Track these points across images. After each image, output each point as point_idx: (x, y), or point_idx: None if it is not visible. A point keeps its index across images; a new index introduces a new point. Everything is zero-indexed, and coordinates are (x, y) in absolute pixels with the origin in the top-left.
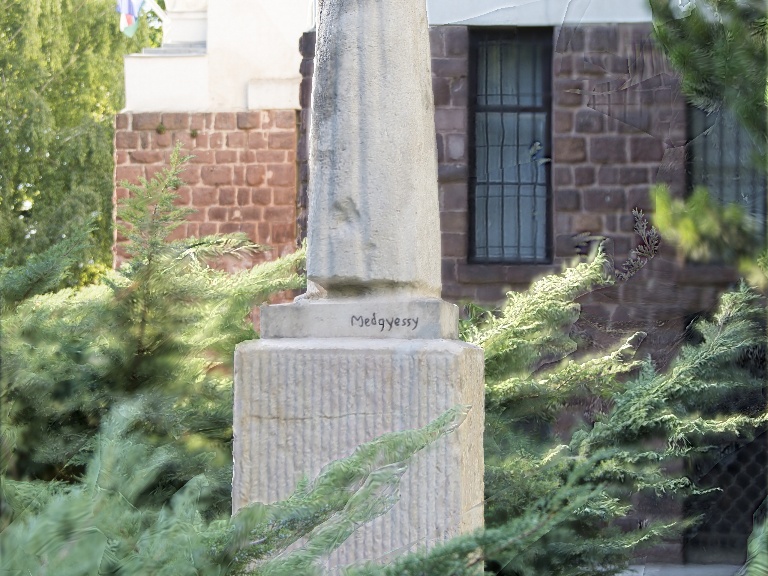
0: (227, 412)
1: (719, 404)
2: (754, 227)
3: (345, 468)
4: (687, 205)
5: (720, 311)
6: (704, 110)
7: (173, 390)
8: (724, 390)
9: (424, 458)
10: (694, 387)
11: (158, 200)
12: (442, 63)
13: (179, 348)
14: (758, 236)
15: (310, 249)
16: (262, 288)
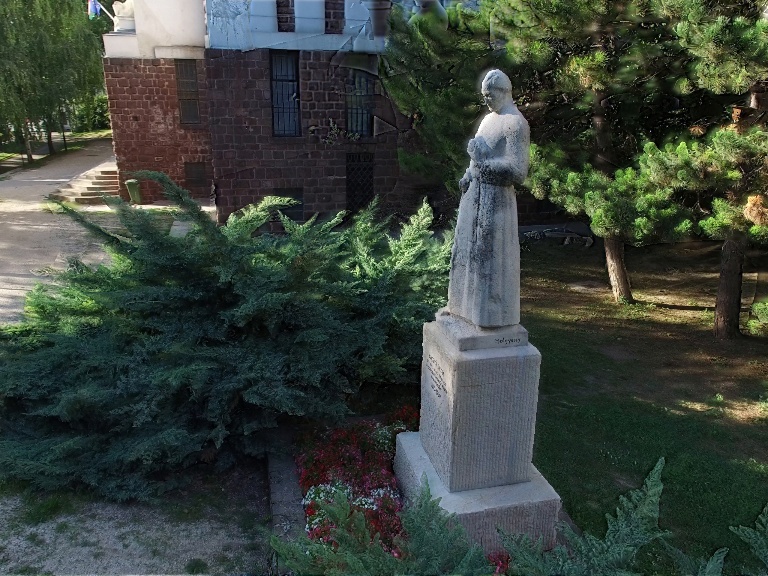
0: None
1: None
2: (436, 166)
3: (652, 515)
4: (408, 155)
5: (456, 216)
6: (407, 116)
7: (303, 284)
8: None
9: (526, 394)
10: None
11: None
12: (261, 63)
13: (310, 273)
14: (437, 169)
15: (480, 315)
16: None
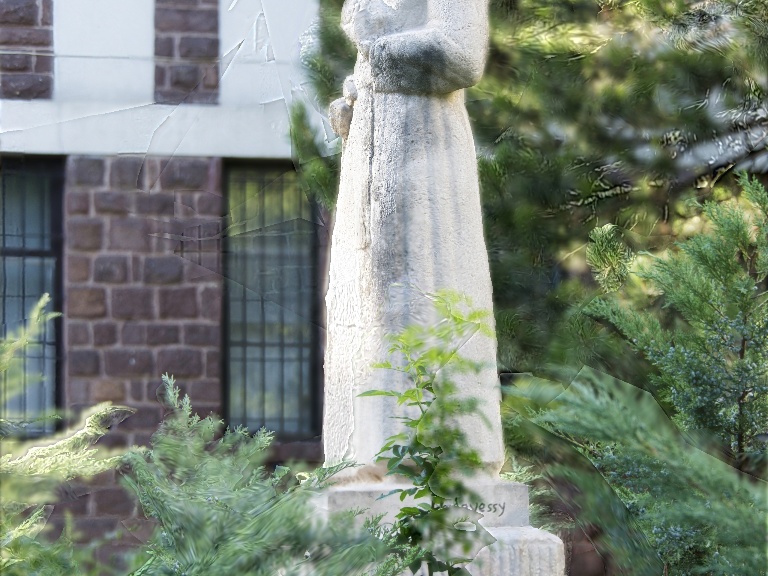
0: None
1: None
2: None
3: None
4: None
5: None
6: None
7: None
8: None
9: None
10: None
11: (5, 365)
12: None
13: None
14: None
15: None
16: (102, 470)
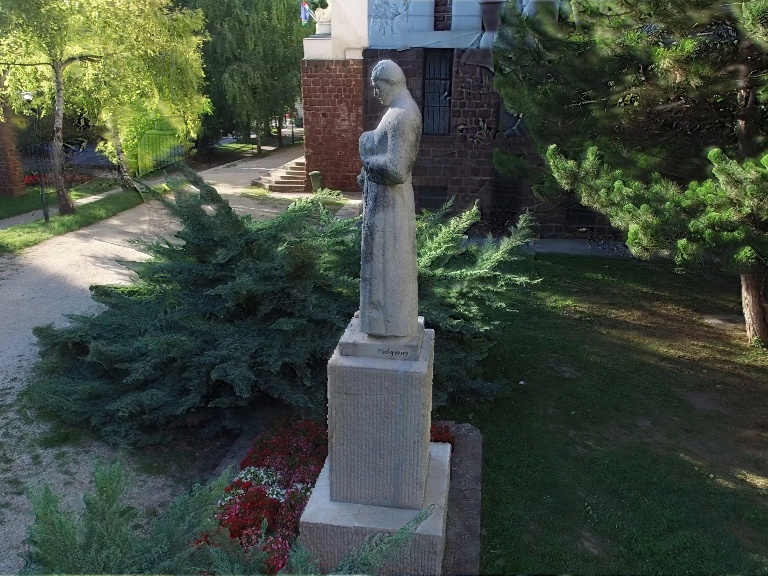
0: (333, 283)
1: (517, 267)
2: (530, 169)
3: (373, 564)
4: (505, 156)
5: (519, 223)
6: (513, 115)
7: (312, 275)
8: (520, 261)
9: (410, 414)
10: (508, 259)
11: None
12: (414, 62)
13: (314, 264)
14: (531, 173)
15: (361, 320)
16: None
